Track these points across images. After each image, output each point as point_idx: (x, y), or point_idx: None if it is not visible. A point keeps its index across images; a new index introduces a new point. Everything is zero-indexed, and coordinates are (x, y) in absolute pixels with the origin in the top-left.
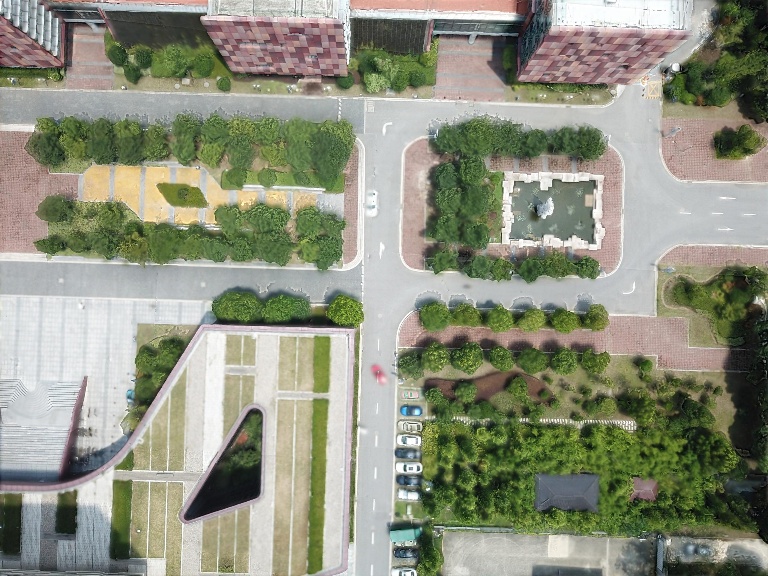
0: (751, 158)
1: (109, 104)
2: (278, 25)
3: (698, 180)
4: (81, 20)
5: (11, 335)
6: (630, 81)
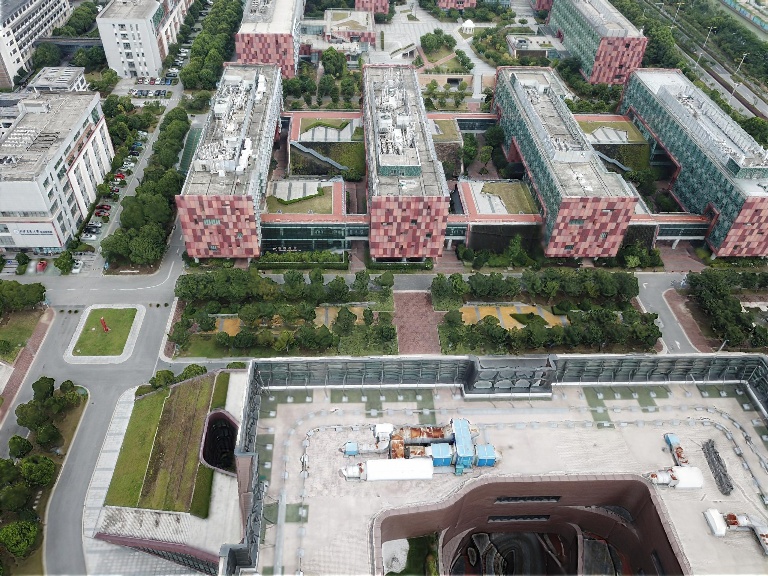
0: None
1: (464, 280)
2: (604, 200)
3: None
4: (449, 237)
5: None
6: None
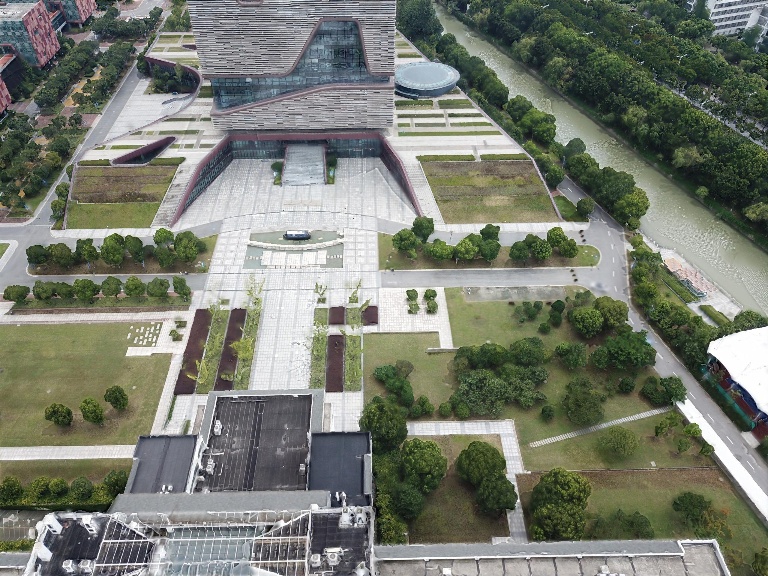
0: (135, 0)
1: None
2: None
3: (138, 6)
4: None
5: (134, 122)
6: (95, 5)
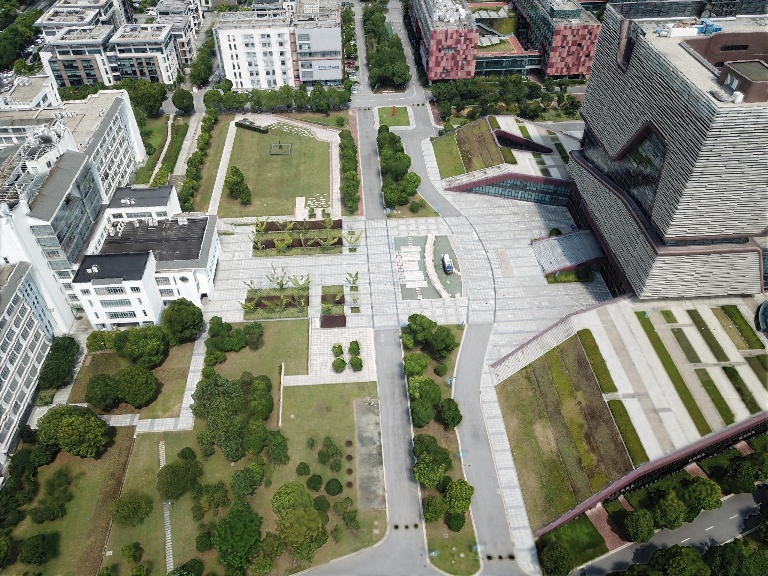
0: None
1: None
2: None
3: None
4: None
5: None
6: None
